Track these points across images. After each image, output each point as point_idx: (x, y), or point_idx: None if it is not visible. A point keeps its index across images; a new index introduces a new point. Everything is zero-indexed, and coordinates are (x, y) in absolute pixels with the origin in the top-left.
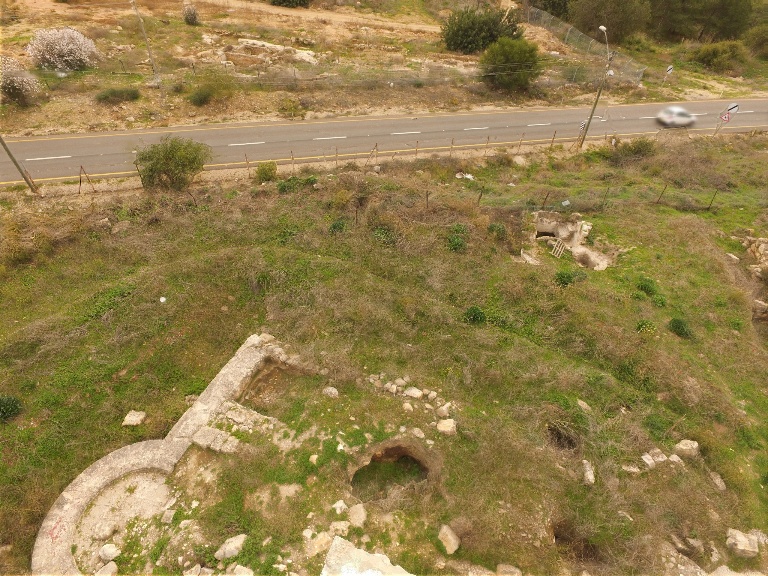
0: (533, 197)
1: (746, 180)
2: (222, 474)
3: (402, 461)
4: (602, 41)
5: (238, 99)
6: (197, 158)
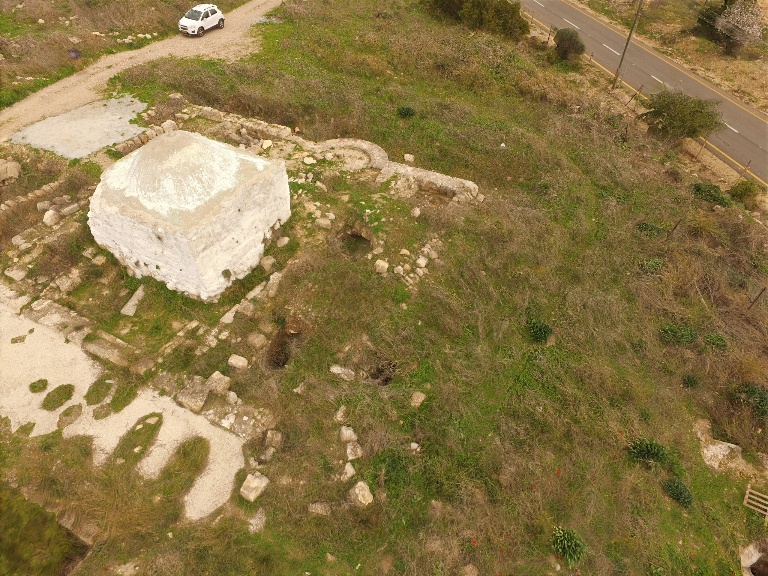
0: None
1: None
2: None
3: None
4: None
5: None
6: (690, 121)
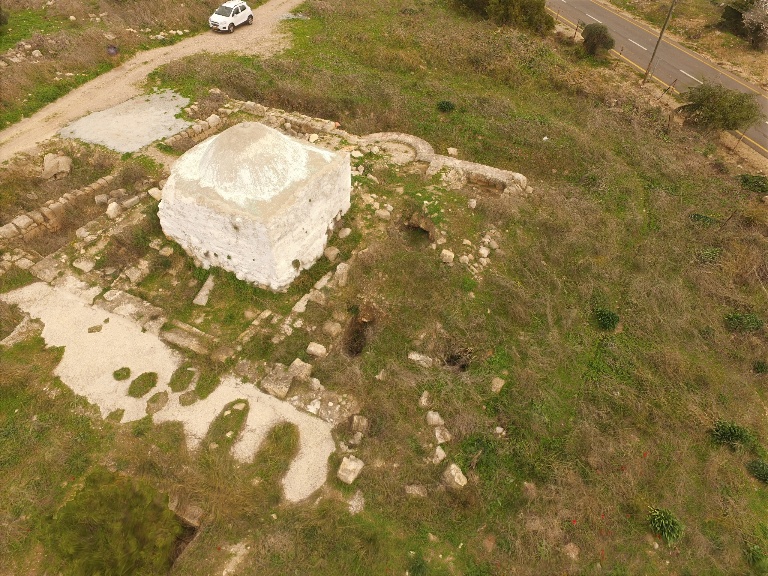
0: None
1: None
2: None
3: None
4: None
5: None
6: (731, 113)
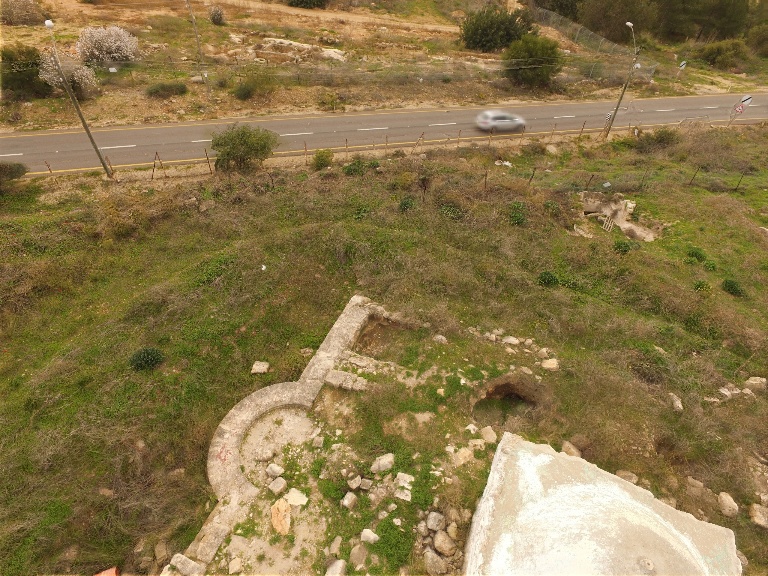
0: (576, 180)
1: (766, 165)
2: (358, 407)
3: (506, 399)
4: (629, 36)
5: (279, 93)
6: (268, 144)
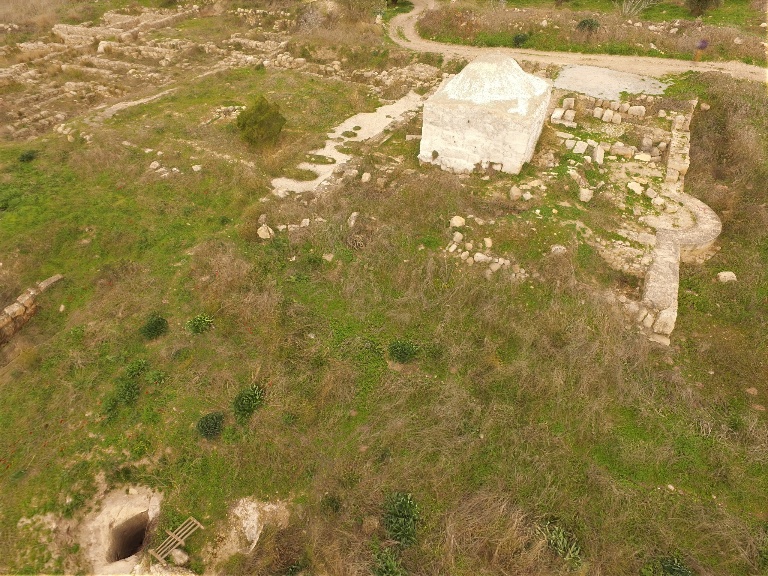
0: None
1: None
2: None
3: None
4: None
5: None
6: None
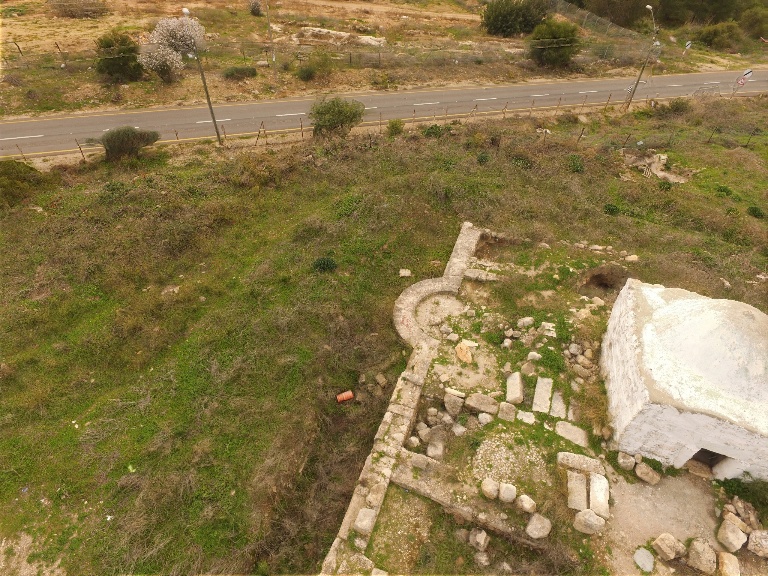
0: (613, 140)
1: None
2: (494, 291)
3: (596, 289)
4: (649, 18)
5: (336, 75)
6: (358, 112)
